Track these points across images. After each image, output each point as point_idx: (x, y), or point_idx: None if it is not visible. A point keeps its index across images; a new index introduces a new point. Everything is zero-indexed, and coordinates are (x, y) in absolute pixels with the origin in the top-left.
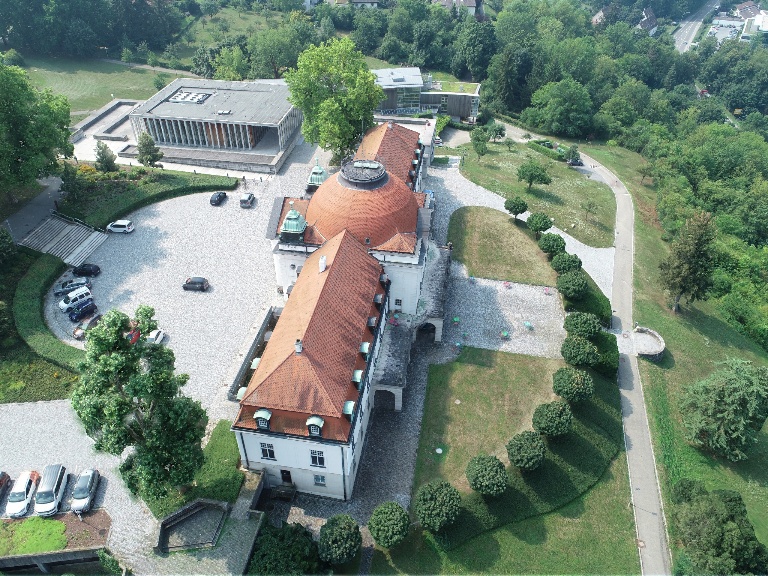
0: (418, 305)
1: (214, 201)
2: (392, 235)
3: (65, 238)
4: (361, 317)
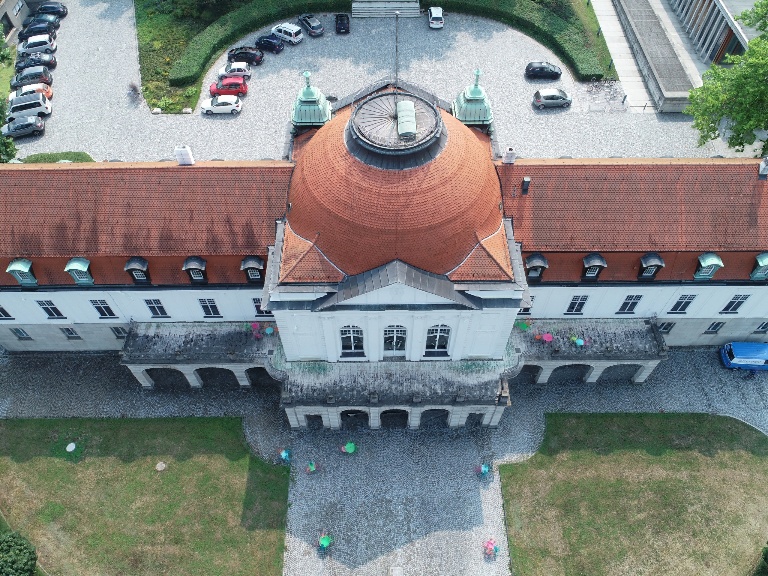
0: (313, 362)
1: (528, 69)
2: (307, 236)
3: None
4: (122, 244)
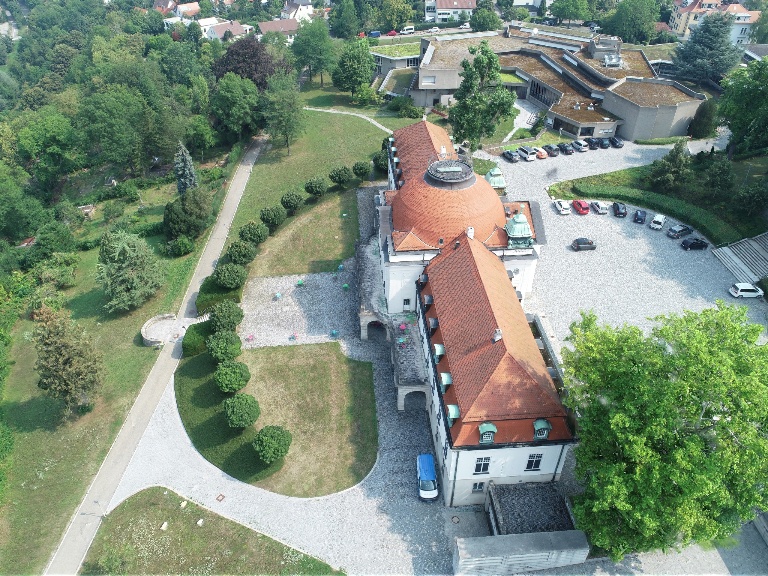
0: (379, 251)
1: None
2: None
3: (761, 258)
4: None
